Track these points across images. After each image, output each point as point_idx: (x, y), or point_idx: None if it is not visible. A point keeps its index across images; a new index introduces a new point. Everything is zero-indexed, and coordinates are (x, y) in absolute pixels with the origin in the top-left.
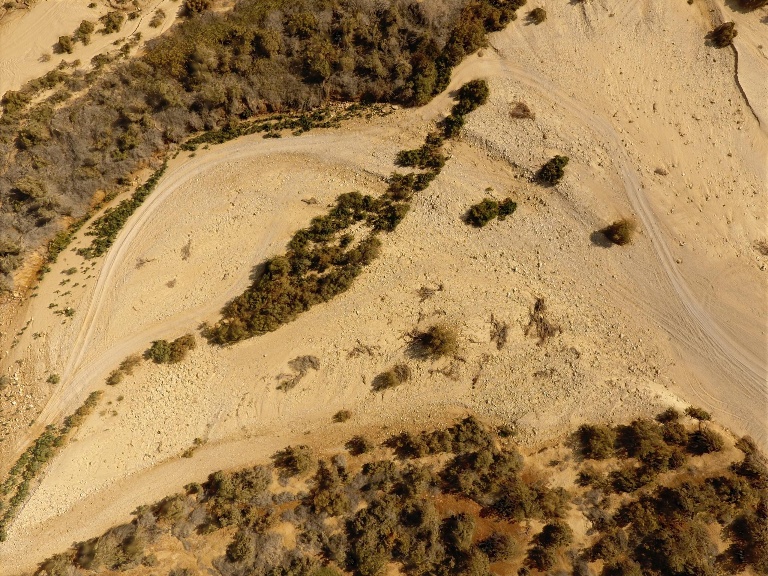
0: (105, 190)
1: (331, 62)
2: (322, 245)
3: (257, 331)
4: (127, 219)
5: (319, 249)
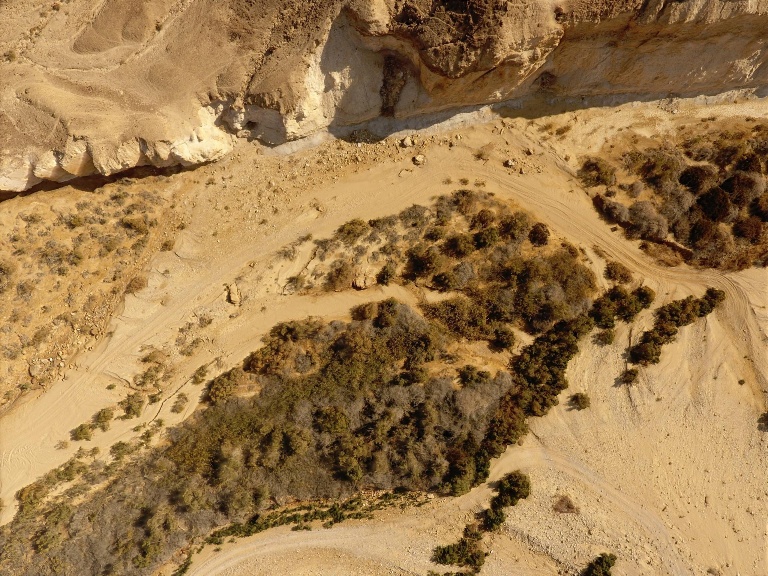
0: None
1: (364, 461)
2: None
3: None
4: None
5: None
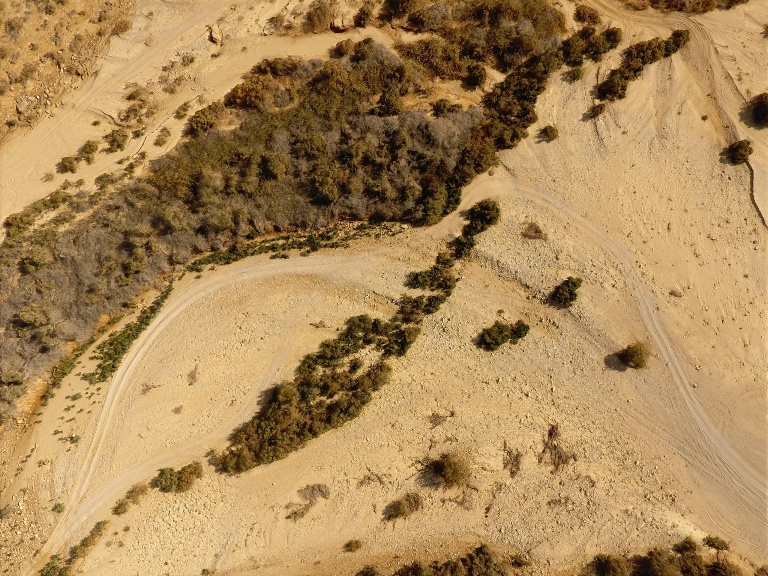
0: (110, 314)
1: (339, 185)
2: (331, 370)
3: (266, 462)
4: (132, 343)
5: (328, 375)
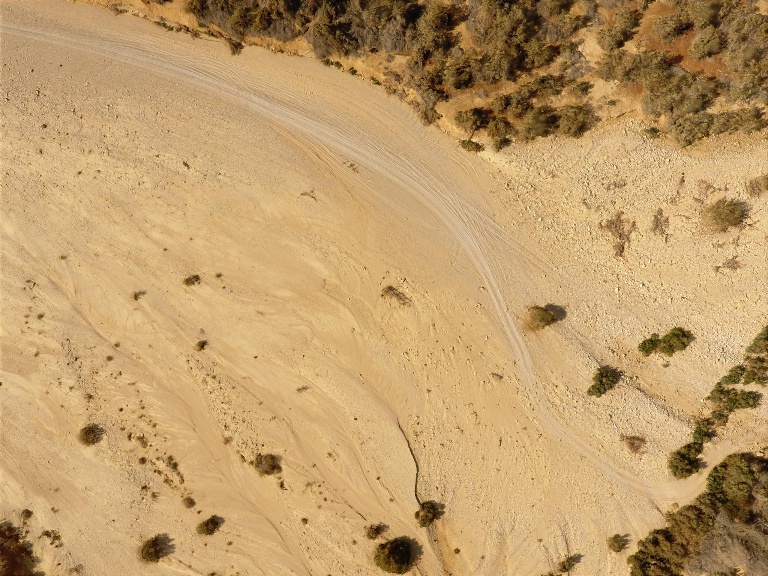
0: None
1: None
2: None
3: None
4: None
5: None
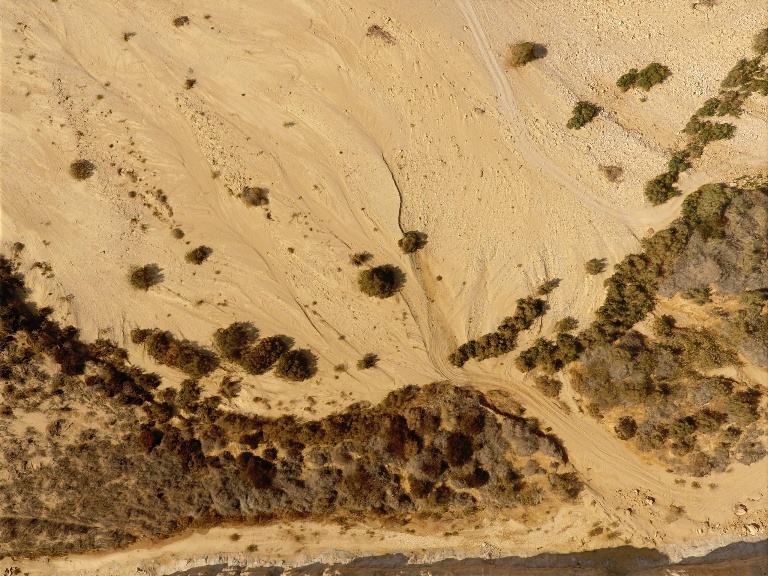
0: None
1: None
2: None
3: None
4: None
5: None
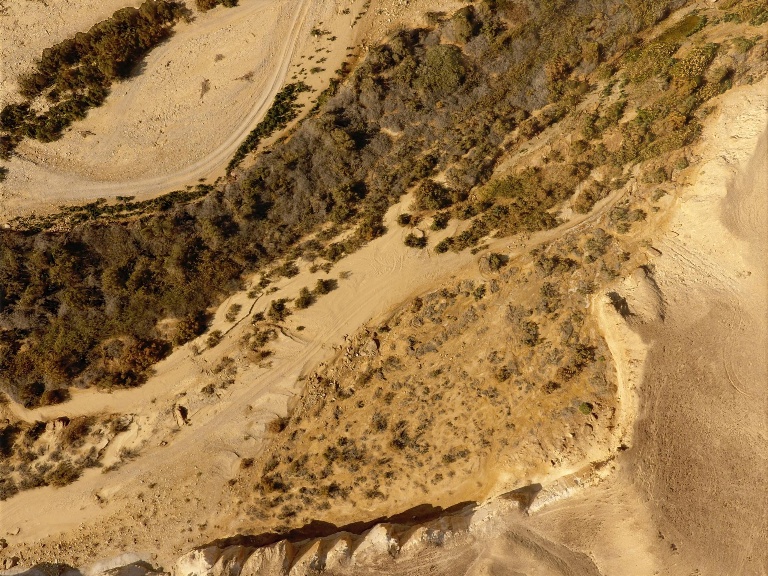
0: None
1: None
2: (77, 93)
3: None
4: None
5: None
